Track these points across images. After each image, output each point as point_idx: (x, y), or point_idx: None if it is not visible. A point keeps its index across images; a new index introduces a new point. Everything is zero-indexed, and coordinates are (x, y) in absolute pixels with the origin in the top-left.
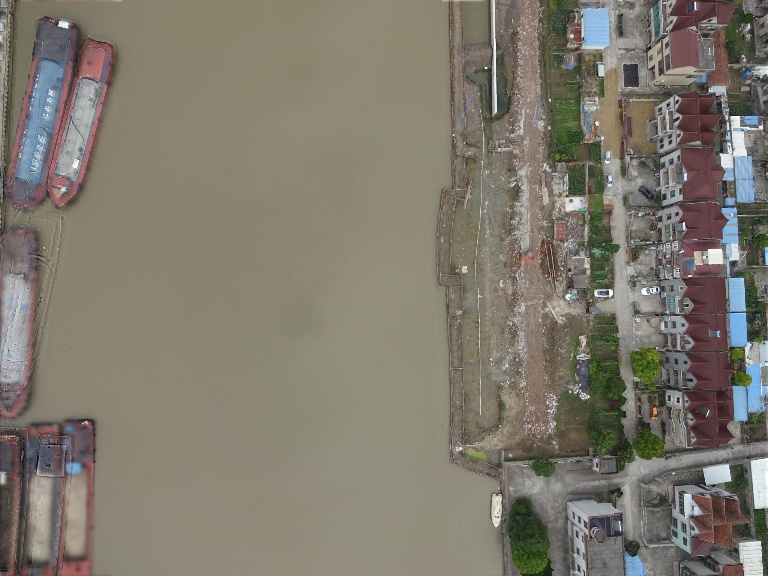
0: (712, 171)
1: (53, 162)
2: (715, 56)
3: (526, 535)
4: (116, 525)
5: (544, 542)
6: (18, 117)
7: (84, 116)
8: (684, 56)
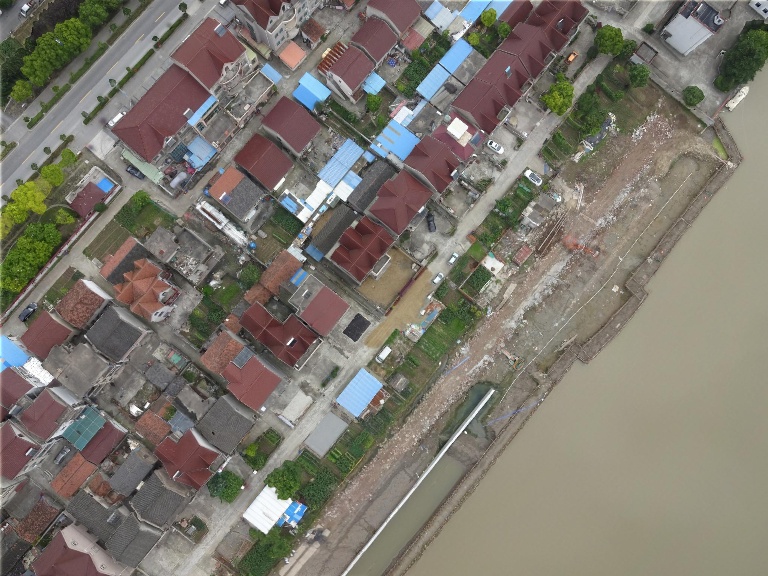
0: (395, 195)
1: None
2: (277, 284)
3: (757, 64)
4: None
5: (753, 47)
6: None
7: None
8: (334, 308)
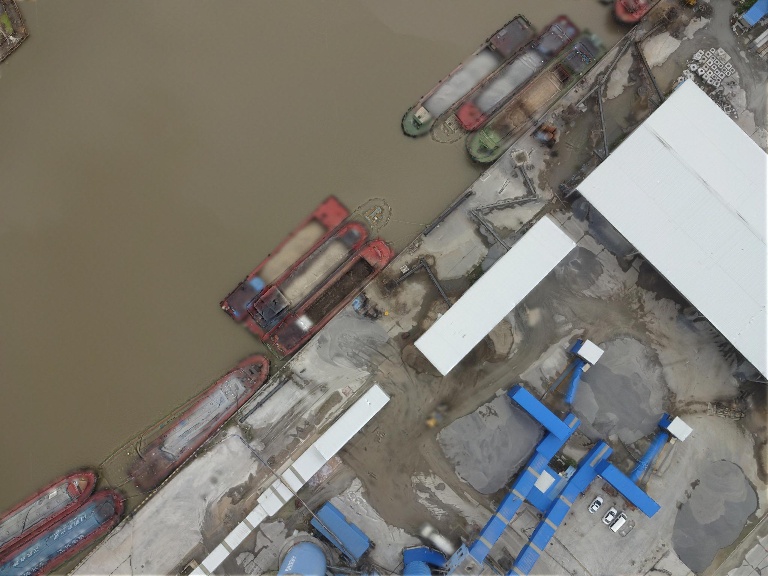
0: None
1: (69, 512)
2: None
3: None
4: (279, 220)
5: None
6: (64, 569)
7: (13, 524)
8: None
